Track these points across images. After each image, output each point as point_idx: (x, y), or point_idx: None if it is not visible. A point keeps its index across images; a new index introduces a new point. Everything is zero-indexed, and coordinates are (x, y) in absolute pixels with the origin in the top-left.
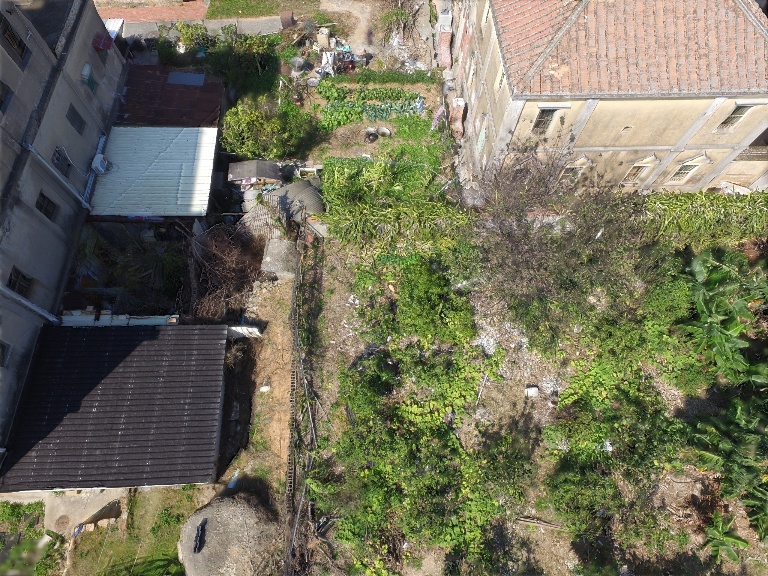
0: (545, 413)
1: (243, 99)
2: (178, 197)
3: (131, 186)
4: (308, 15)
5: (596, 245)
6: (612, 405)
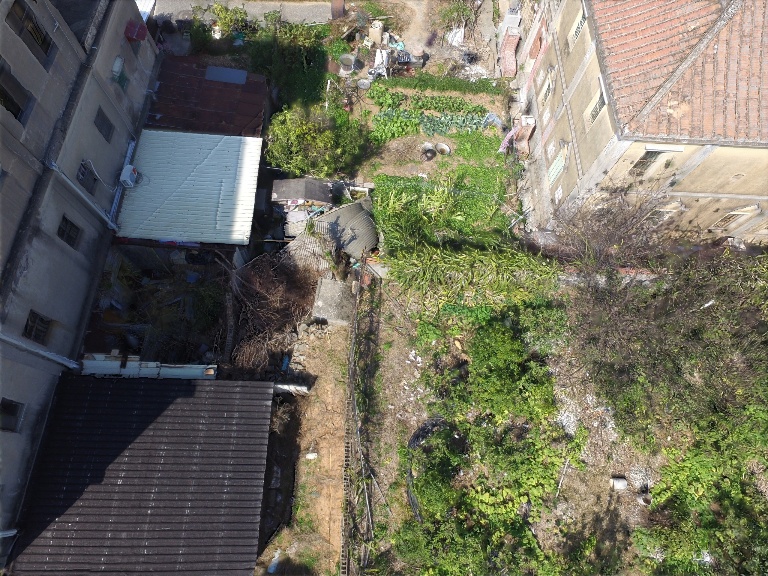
0: (633, 510)
1: (286, 99)
2: (217, 220)
3: (163, 203)
4: (358, 3)
5: (701, 316)
6: (709, 505)
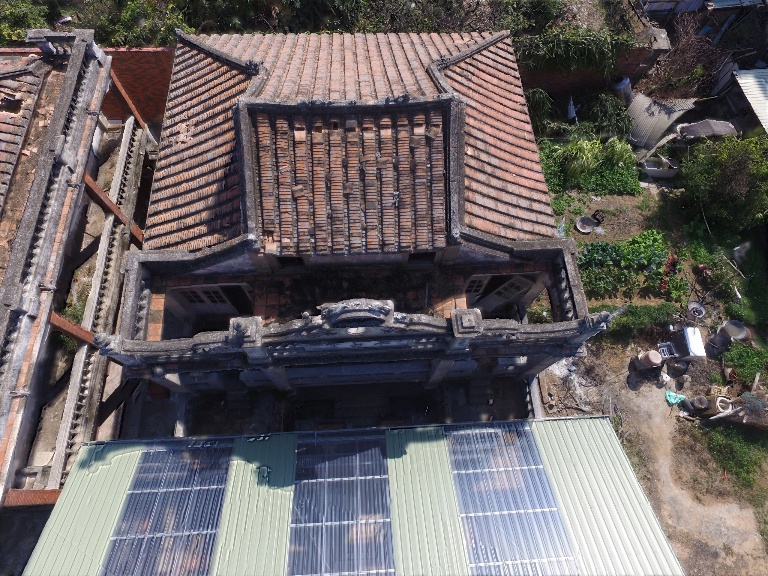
0: None
1: None
2: (767, 84)
3: None
4: (765, 482)
5: None
6: None
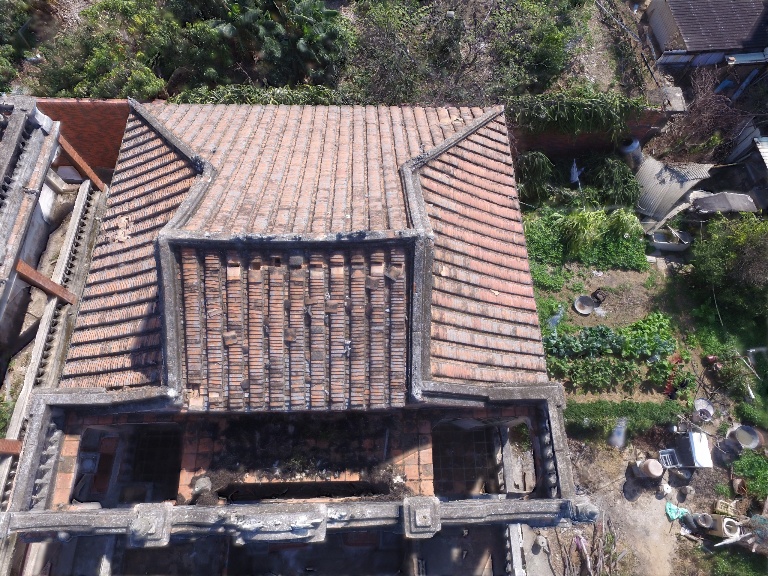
0: (442, 5)
1: None
2: None
3: None
4: None
5: None
6: (394, 6)
